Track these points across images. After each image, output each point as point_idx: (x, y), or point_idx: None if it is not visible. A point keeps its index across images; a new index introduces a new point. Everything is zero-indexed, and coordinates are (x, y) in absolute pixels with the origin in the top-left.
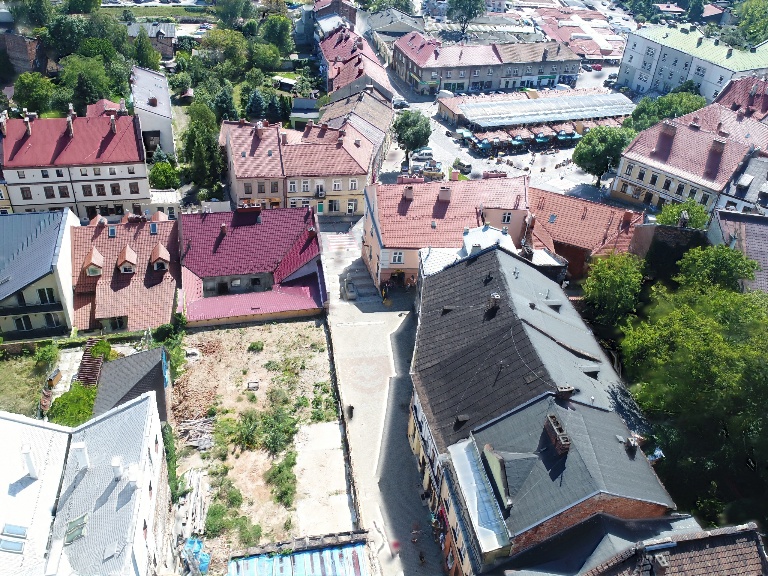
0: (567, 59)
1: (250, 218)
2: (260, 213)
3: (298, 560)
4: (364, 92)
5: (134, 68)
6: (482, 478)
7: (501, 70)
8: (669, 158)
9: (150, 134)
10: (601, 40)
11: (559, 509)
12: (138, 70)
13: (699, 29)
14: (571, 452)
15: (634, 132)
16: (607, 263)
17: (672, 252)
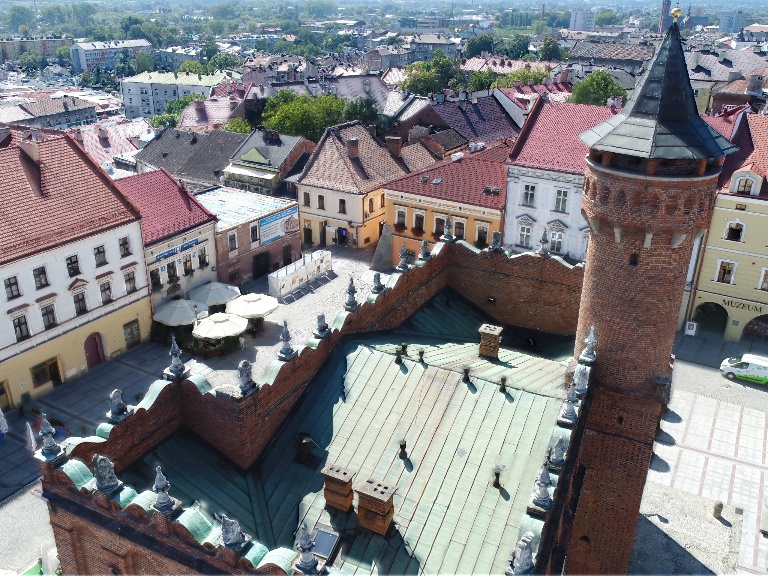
0: (84, 107)
1: None
2: None
3: (198, 196)
4: None
5: None
6: (248, 168)
7: (36, 123)
8: (209, 121)
9: None
10: (95, 99)
11: (290, 150)
12: None
13: None
14: (281, 137)
15: (177, 115)
16: (229, 128)
17: (257, 114)
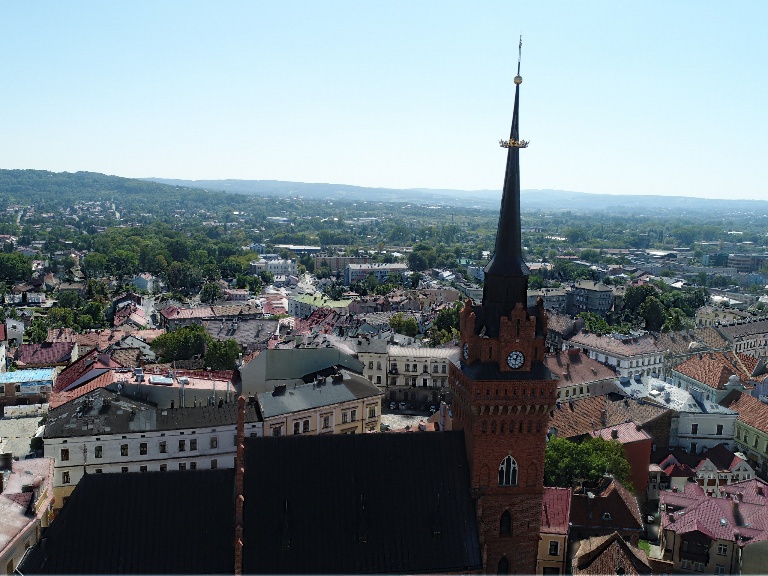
0: (254, 313)
1: (48, 345)
2: (53, 344)
3: None
4: (126, 324)
5: (7, 318)
6: None
7: None
8: None
9: (12, 340)
10: None
11: None
12: (9, 319)
13: (327, 296)
14: None
15: None
16: None
17: None
